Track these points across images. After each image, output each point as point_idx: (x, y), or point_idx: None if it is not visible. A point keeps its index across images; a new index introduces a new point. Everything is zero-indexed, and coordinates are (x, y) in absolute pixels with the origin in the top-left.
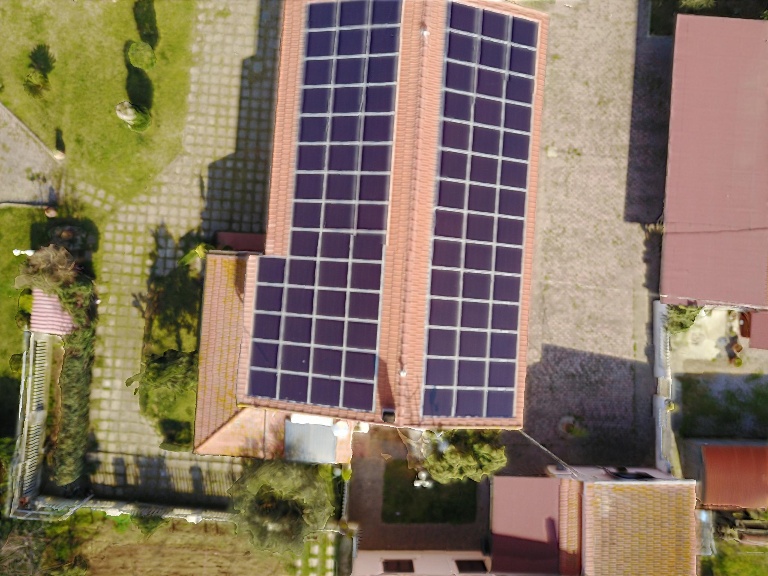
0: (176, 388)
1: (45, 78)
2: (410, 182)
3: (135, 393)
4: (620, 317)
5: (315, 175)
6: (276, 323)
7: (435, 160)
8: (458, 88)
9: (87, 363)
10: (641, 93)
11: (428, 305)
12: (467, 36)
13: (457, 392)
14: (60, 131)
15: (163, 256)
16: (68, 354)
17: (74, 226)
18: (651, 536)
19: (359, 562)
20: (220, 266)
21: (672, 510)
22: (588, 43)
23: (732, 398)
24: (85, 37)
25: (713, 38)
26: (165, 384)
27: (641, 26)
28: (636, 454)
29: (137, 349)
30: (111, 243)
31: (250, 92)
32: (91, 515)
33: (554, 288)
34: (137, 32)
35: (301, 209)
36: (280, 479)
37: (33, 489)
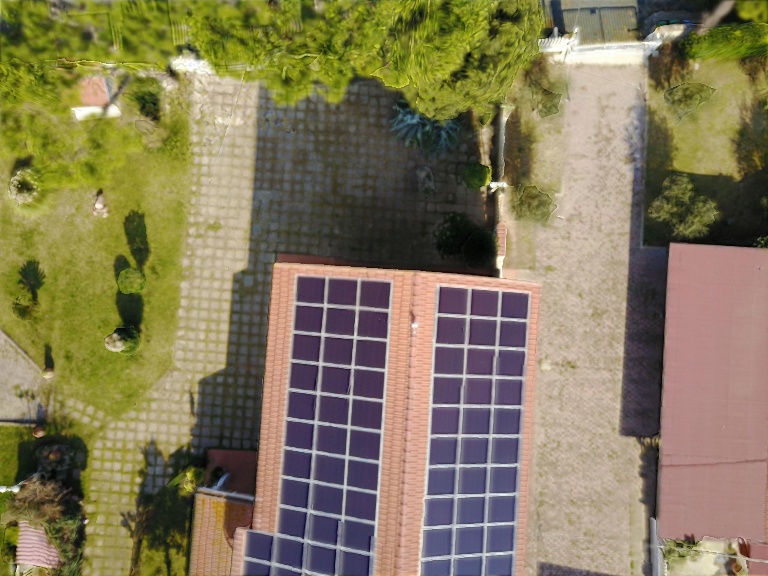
0: None
1: (34, 300)
2: (398, 474)
3: None
4: (616, 534)
5: (302, 454)
6: None
7: (424, 449)
8: (447, 372)
9: None
10: (635, 304)
11: None
12: (456, 318)
13: None
14: (49, 348)
15: (152, 473)
16: None
17: (62, 444)
18: None
19: None
20: (208, 506)
21: None
22: (581, 254)
23: None
24: (75, 253)
25: (706, 266)
26: None
27: (634, 237)
28: None
29: (125, 570)
30: (99, 461)
31: (240, 306)
32: None
33: (549, 504)
34: (127, 247)
35: (288, 486)
36: None
37: None
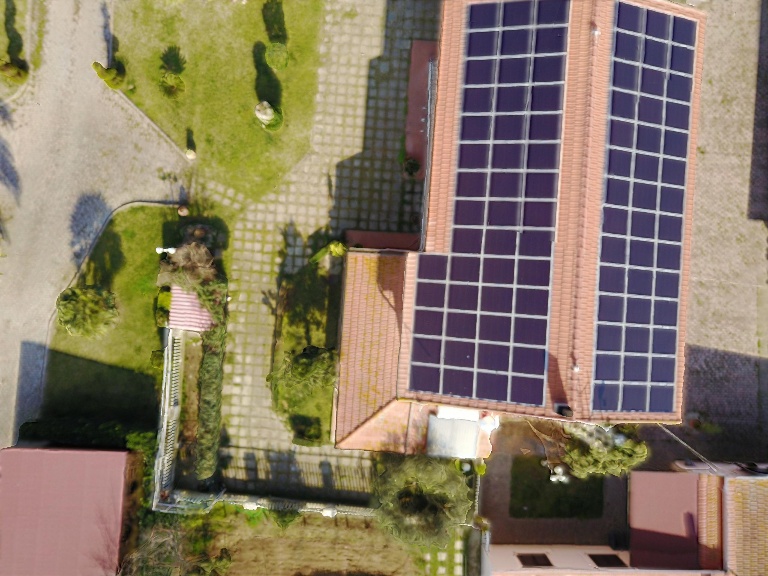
0: (317, 384)
1: (180, 79)
2: (580, 180)
3: (275, 389)
4: (744, 314)
5: (478, 173)
6: (438, 319)
7: (603, 158)
8: (624, 87)
9: (221, 359)
10: (764, 91)
11: (597, 301)
12: (632, 36)
13: (623, 387)
14: (191, 131)
15: (292, 254)
16: (208, 350)
17: (205, 224)
18: None
19: (493, 556)
20: (361, 263)
21: None
22: (711, 42)
23: None
24: (215, 38)
25: None
26: (308, 380)
27: (764, 25)
28: (761, 450)
29: (267, 346)
30: (241, 241)
31: (377, 92)
32: (224, 509)
33: None
34: (266, 33)
35: (463, 207)
36: (431, 473)
37: (169, 483)
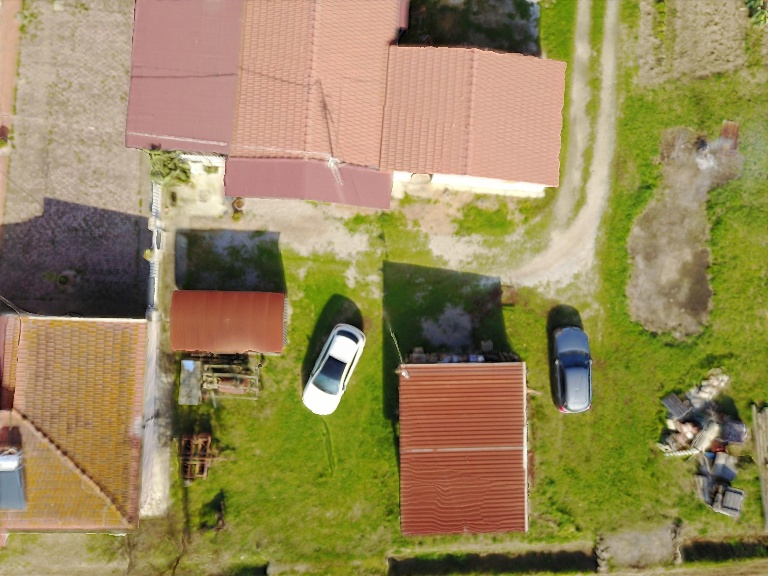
0: None
1: None
2: None
3: None
4: (126, 173)
5: None
6: None
7: None
8: None
9: None
10: None
11: None
12: None
13: None
14: None
15: None
16: None
17: None
18: (92, 373)
19: None
20: None
21: (117, 348)
22: None
23: (237, 255)
24: None
25: None
26: None
27: None
28: (137, 309)
29: None
30: None
31: None
32: None
33: (58, 143)
34: None
35: None
36: None
37: None
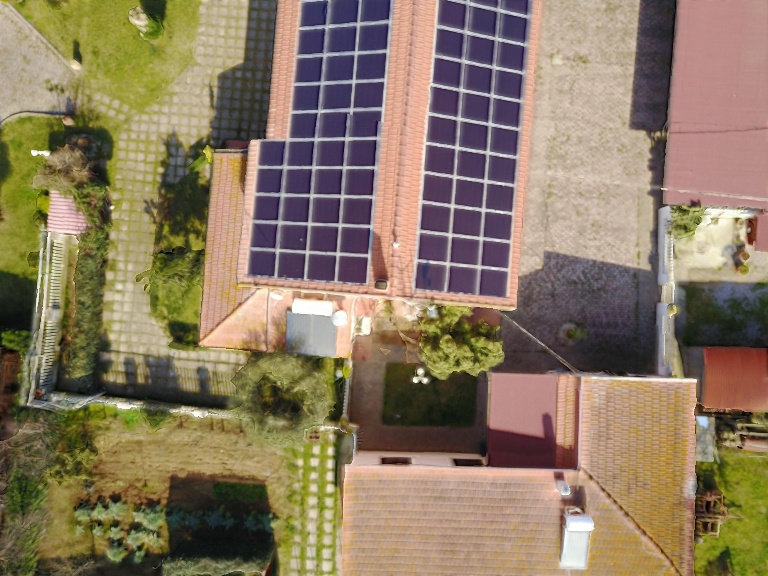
0: (183, 283)
1: None
2: (405, 58)
3: (145, 288)
4: (624, 225)
5: (314, 58)
6: (275, 204)
7: (430, 38)
8: None
9: (101, 264)
10: None
11: (422, 180)
12: None
13: (450, 268)
14: (77, 43)
15: (174, 164)
16: (82, 251)
17: (90, 134)
18: (649, 433)
19: (359, 458)
20: (226, 164)
21: (671, 408)
22: None
23: (738, 308)
24: None
25: None
26: (173, 278)
27: None
28: (638, 362)
29: (148, 253)
30: (124, 151)
31: (258, 3)
32: (104, 411)
33: (557, 196)
34: None
35: (300, 92)
36: (280, 364)
37: (50, 384)
